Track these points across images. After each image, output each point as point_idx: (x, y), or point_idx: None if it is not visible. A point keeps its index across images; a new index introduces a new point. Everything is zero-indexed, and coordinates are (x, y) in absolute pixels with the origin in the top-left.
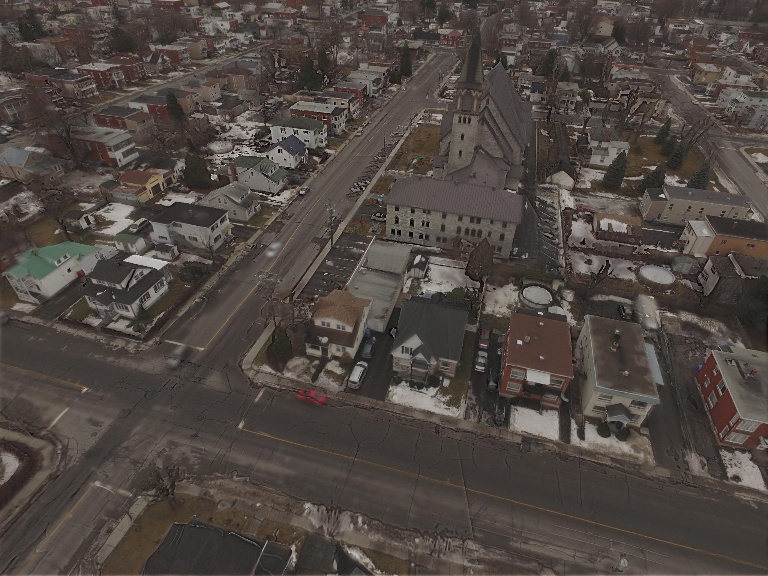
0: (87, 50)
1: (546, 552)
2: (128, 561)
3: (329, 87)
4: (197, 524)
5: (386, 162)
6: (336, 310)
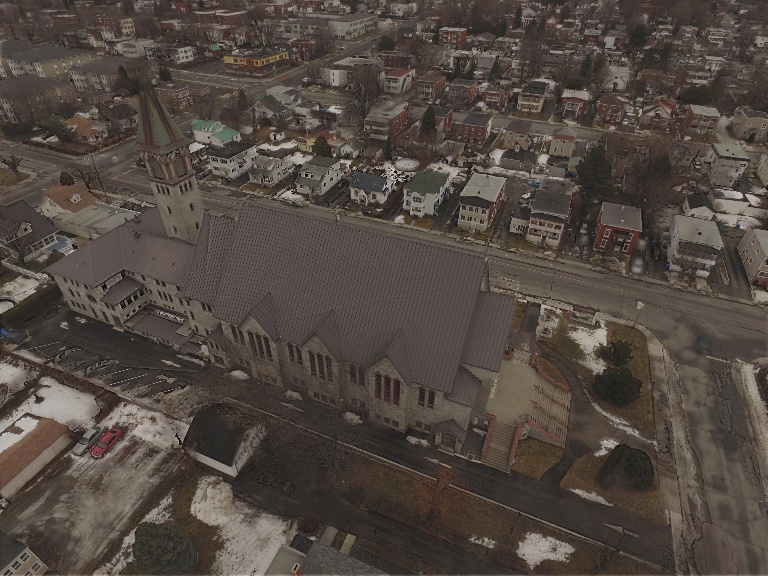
0: (642, 86)
1: None
2: None
3: (608, 202)
4: None
5: None
6: (57, 188)
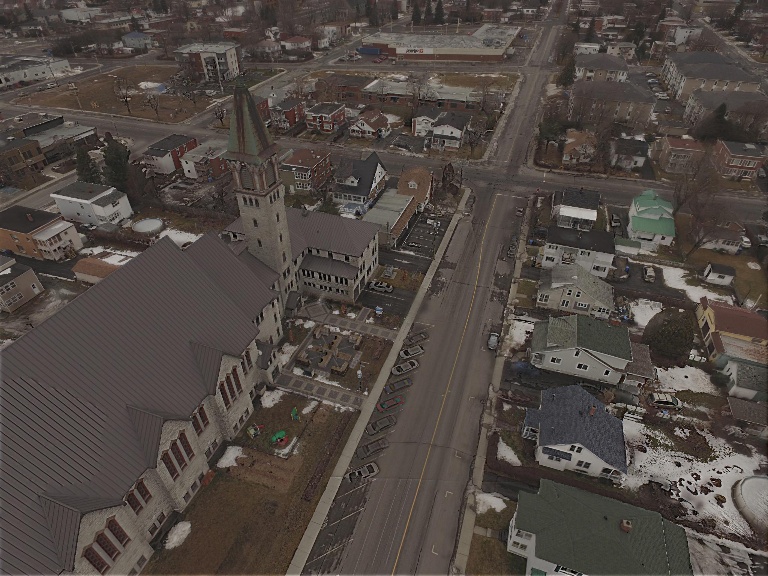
0: None
1: (339, 149)
2: (478, 149)
3: None
4: (457, 139)
5: (353, 445)
6: (419, 170)
